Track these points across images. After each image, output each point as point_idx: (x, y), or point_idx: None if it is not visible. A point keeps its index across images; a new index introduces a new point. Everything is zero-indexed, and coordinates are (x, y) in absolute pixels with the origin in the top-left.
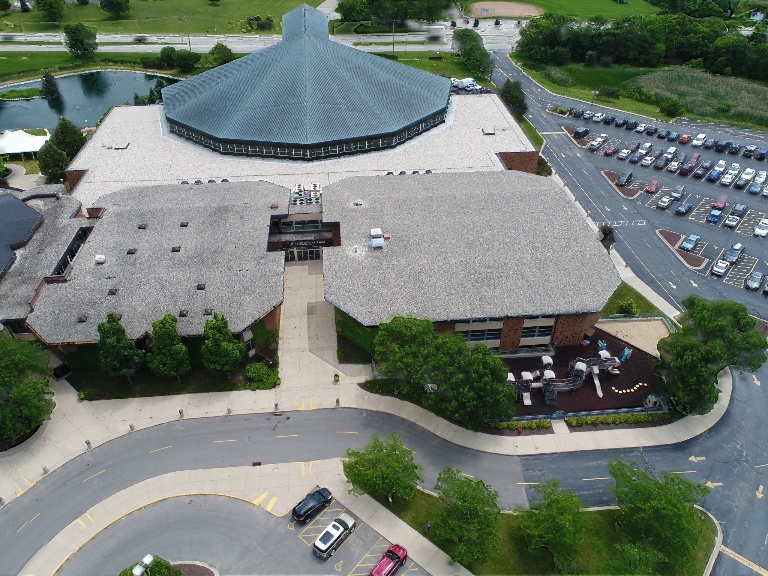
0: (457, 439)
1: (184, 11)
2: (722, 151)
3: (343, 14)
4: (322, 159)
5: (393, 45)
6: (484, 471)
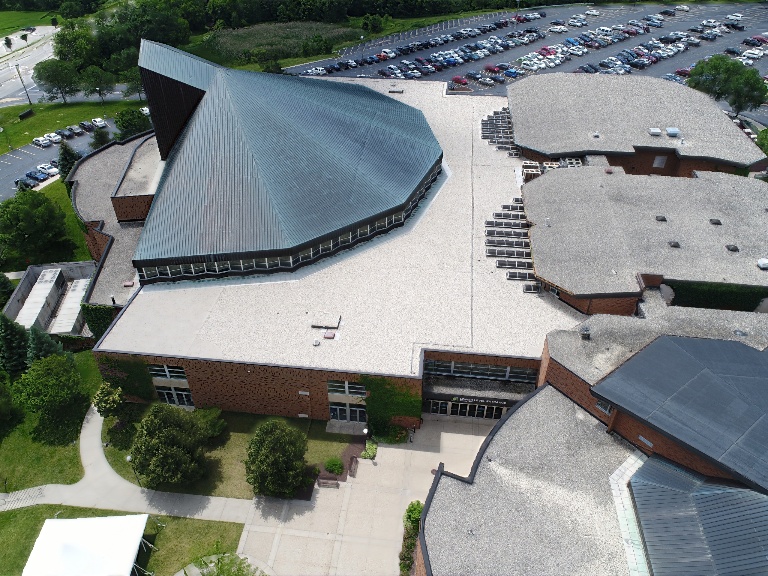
0: None
1: None
2: (408, 53)
3: None
4: None
5: None
6: None
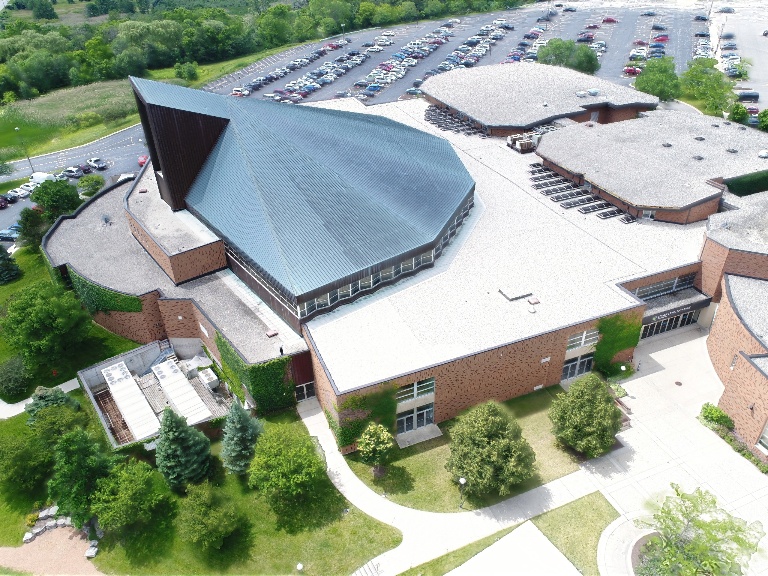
0: None
1: None
2: None
3: None
4: None
5: None
6: (672, 107)
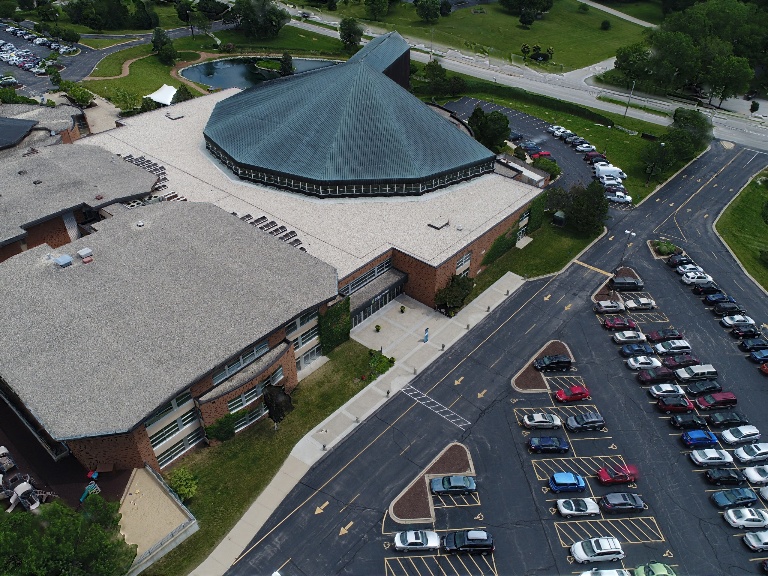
0: None
1: (486, 27)
2: None
3: (616, 62)
4: (252, 182)
5: (627, 108)
6: None
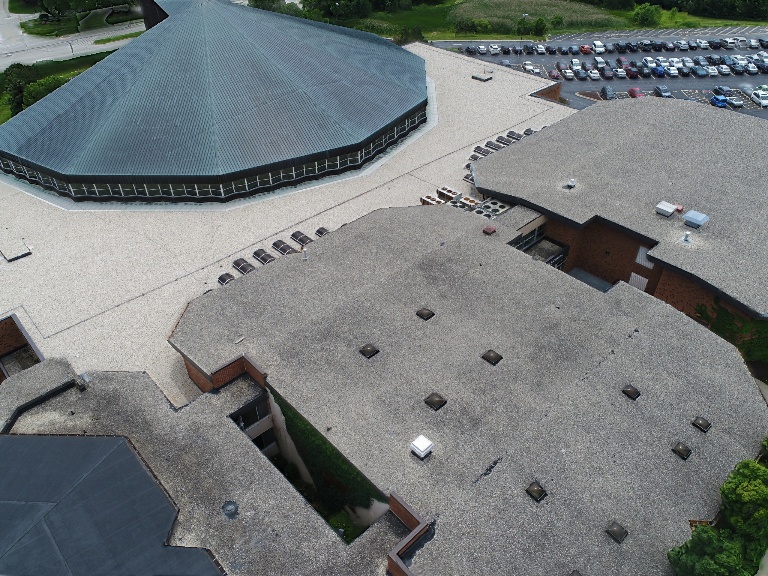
0: None
1: None
2: (625, 52)
3: (55, 7)
4: (371, 160)
5: None
6: None
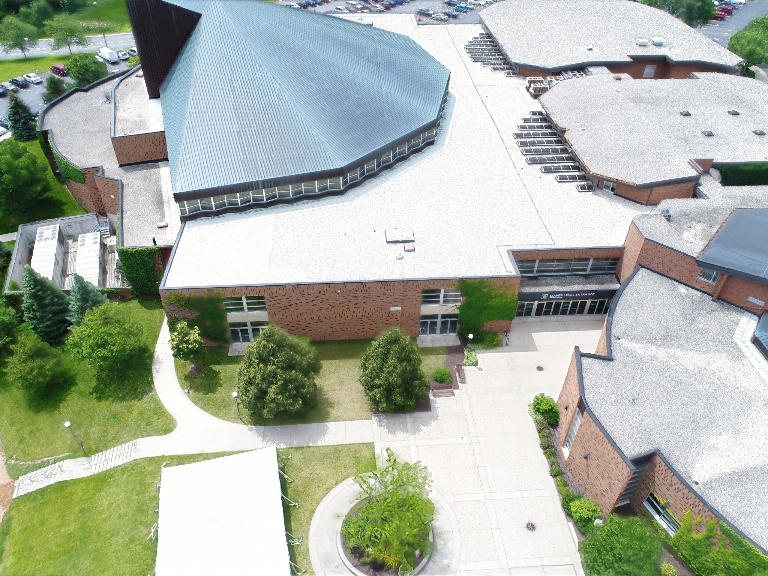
0: (765, 79)
1: None
2: None
3: None
4: None
5: None
6: None
